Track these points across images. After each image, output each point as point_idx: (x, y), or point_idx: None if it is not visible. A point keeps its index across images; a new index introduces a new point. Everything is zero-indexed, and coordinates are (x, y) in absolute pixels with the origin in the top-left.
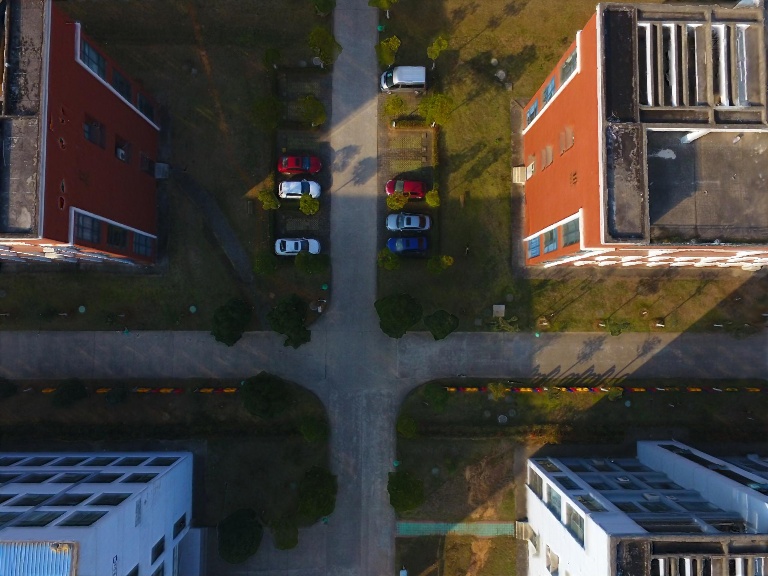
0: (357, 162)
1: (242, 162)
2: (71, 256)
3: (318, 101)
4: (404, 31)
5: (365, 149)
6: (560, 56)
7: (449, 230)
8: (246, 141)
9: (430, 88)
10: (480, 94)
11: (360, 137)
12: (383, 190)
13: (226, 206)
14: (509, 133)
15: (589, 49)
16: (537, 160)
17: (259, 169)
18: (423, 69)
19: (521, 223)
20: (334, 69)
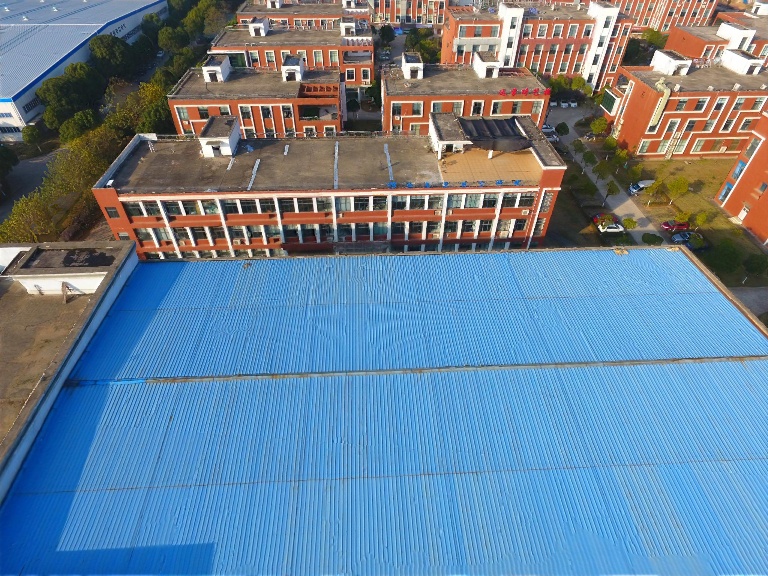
0: (636, 220)
1: (569, 221)
2: (510, 237)
3: (598, 200)
4: (628, 177)
5: (637, 215)
6: (716, 183)
7: (714, 242)
8: (567, 214)
9: (657, 193)
10: (686, 194)
11: (630, 211)
12: (659, 229)
13: (569, 238)
14: (713, 207)
15: (766, 129)
16: (749, 201)
17: (581, 223)
18: (654, 181)
19: (755, 238)
20: (599, 190)
